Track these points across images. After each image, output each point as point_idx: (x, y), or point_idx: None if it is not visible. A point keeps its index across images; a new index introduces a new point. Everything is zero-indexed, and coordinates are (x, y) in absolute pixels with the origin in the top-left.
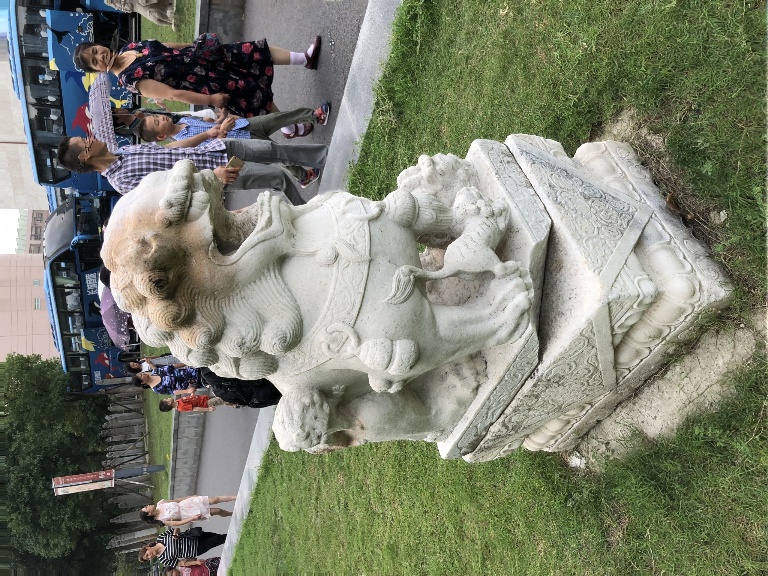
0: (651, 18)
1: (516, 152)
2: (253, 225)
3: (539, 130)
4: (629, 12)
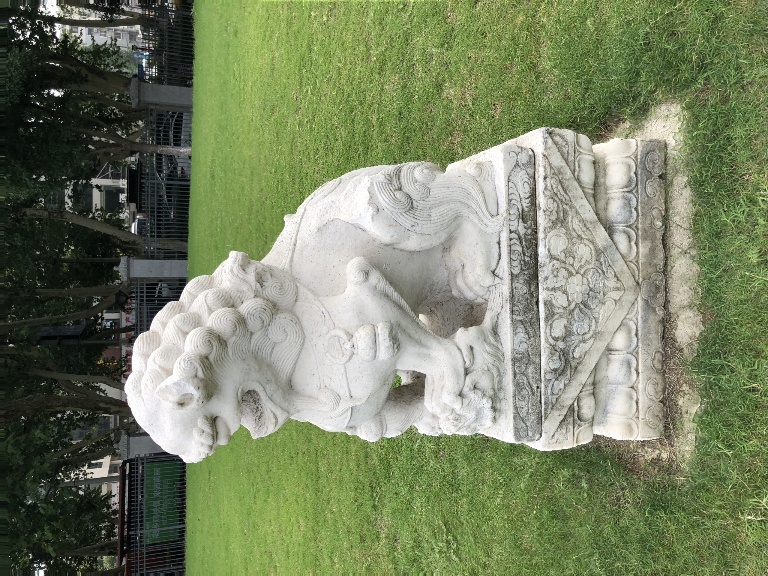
0: (700, 567)
1: (526, 443)
2: (258, 401)
3: (759, 380)
4: (725, 569)
